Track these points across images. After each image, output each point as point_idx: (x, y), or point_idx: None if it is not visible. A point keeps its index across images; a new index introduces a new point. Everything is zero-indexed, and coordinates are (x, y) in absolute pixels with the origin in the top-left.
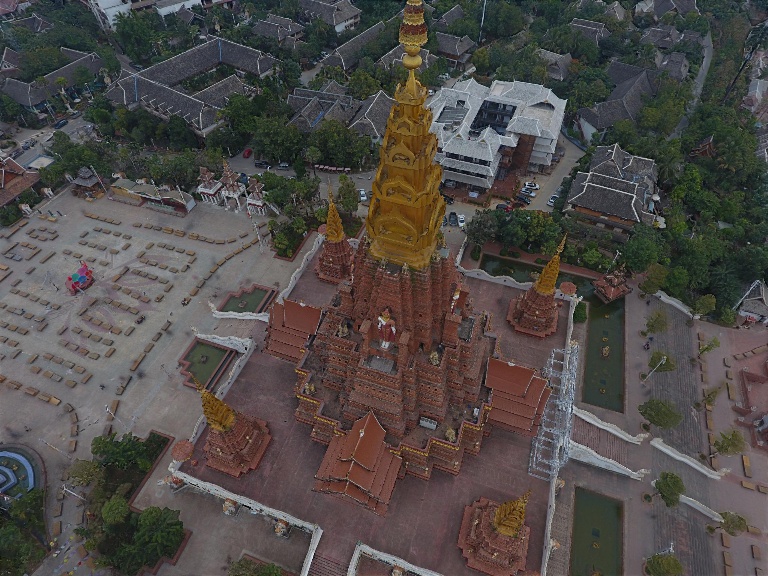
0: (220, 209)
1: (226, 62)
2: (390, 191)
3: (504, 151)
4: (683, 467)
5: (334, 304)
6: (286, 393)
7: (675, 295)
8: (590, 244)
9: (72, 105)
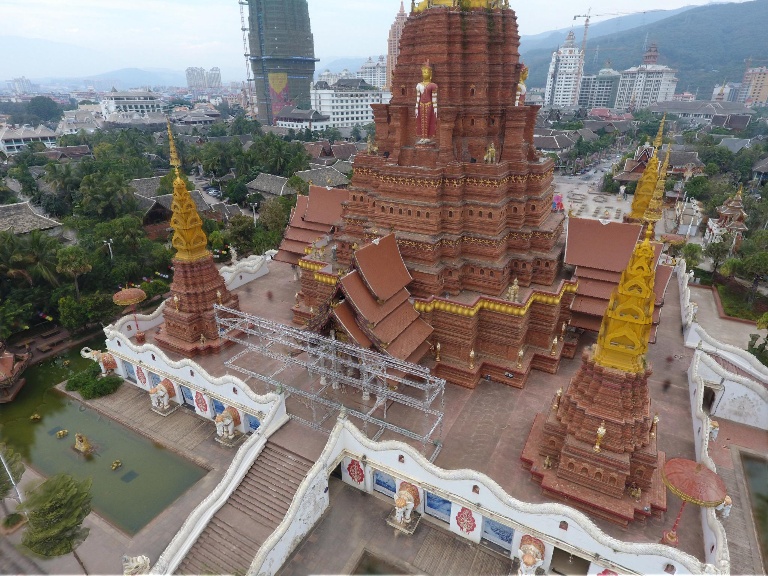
0: None
1: None
2: None
3: None
4: None
5: None
6: None
7: None
8: None
9: None
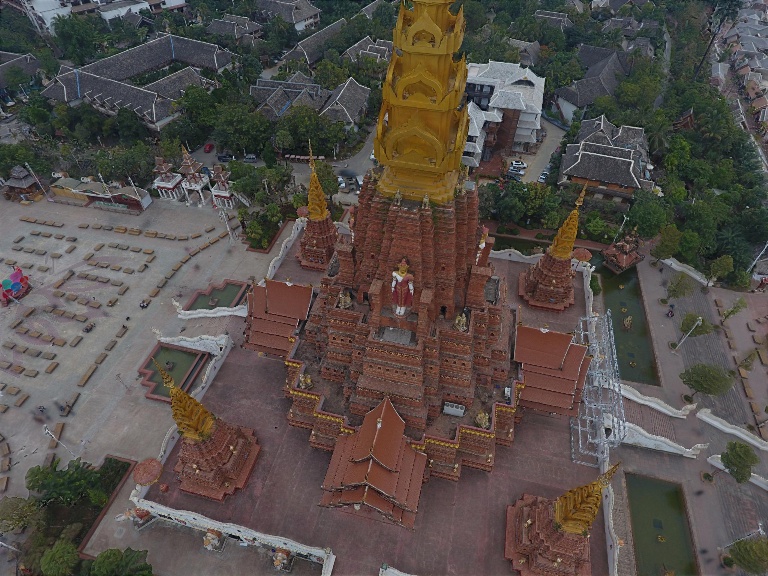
0: (181, 205)
1: (180, 59)
2: (406, 94)
3: (489, 128)
4: (734, 440)
5: (330, 274)
6: (274, 394)
7: (686, 261)
8: (592, 214)
9: (5, 109)
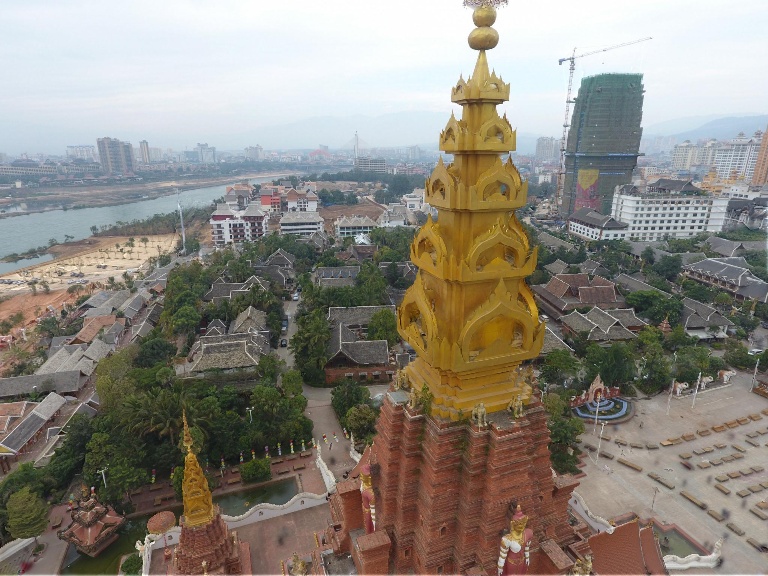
0: None
1: None
2: None
3: None
4: None
5: None
6: None
7: None
8: None
9: None
